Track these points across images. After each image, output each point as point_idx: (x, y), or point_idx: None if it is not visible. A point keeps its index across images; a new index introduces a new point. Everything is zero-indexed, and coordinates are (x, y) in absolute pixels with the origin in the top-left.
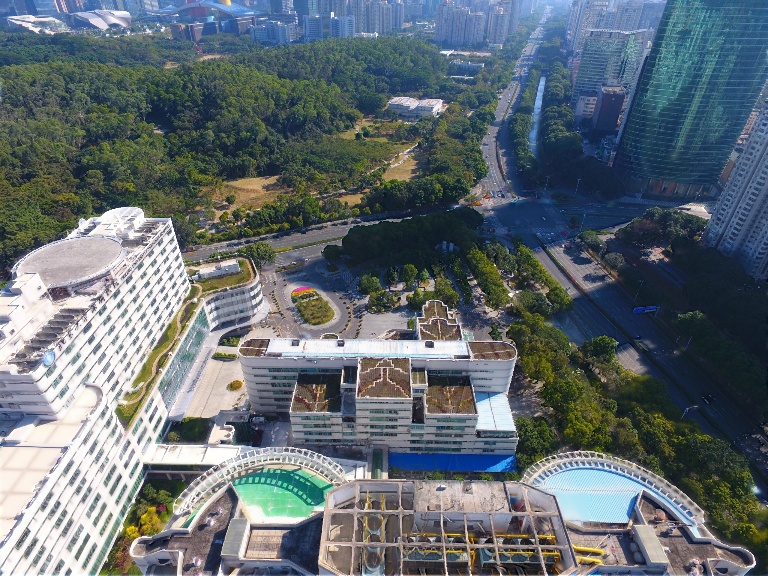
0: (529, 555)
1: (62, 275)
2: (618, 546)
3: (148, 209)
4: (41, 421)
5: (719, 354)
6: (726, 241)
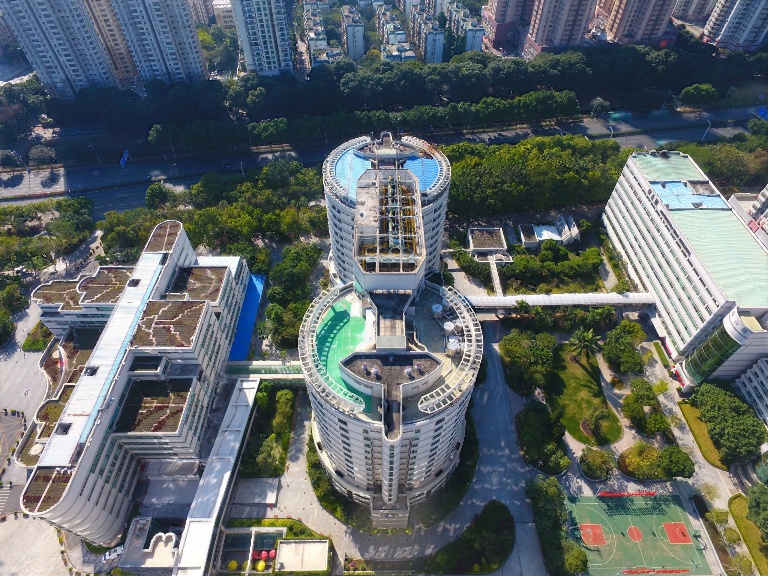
0: (400, 188)
1: None
2: (385, 167)
3: None
4: None
5: (202, 134)
6: (76, 81)
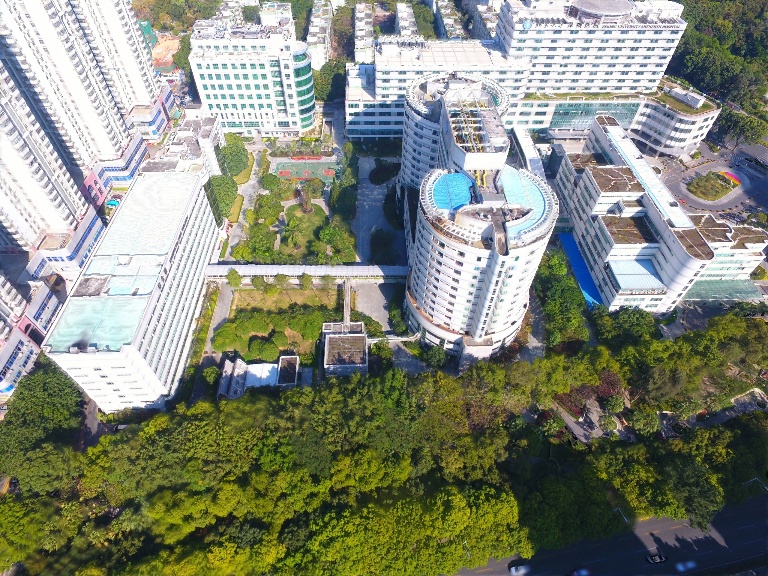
0: None
1: (585, 5)
2: None
3: (760, 66)
4: (504, 56)
5: None
6: None
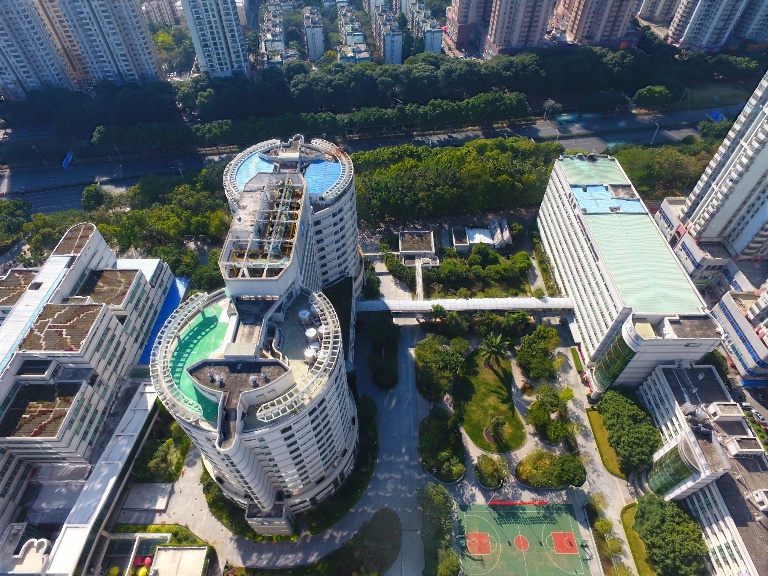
0: None
1: None
2: (286, 170)
3: None
4: None
5: (144, 136)
6: (27, 82)
